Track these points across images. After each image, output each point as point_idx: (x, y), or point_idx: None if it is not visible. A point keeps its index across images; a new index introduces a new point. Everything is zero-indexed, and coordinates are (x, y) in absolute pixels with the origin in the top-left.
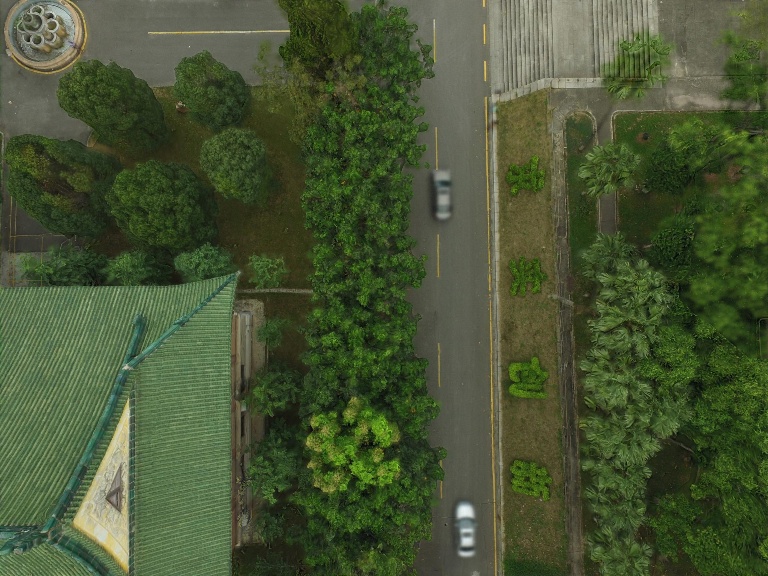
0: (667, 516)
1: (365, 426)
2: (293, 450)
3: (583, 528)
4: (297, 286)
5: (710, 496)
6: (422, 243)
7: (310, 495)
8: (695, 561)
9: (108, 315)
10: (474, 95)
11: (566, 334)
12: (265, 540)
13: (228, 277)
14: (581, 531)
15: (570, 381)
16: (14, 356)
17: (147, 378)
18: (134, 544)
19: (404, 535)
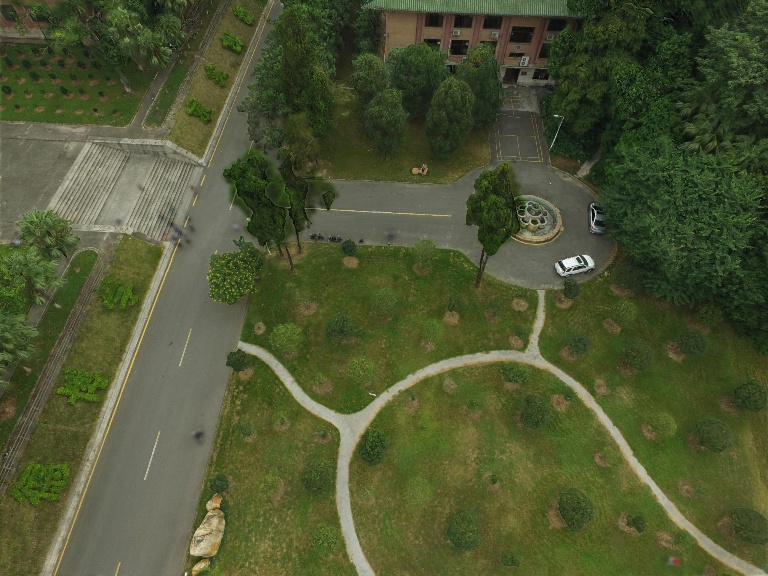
0: None
1: None
2: (357, 7)
3: None
4: None
5: None
6: None
7: None
8: None
9: None
10: (216, 169)
11: None
12: None
13: (367, 5)
14: None
15: None
16: None
17: None
18: None
19: None
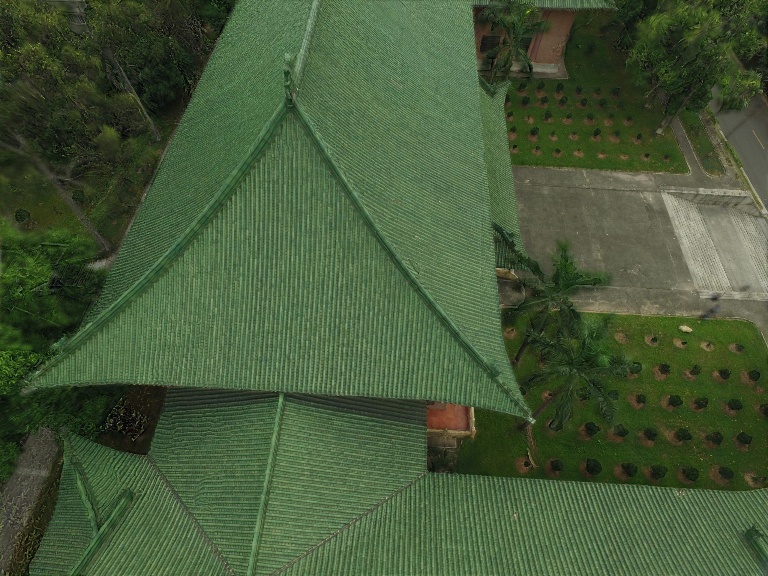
0: None
1: None
2: None
3: None
4: None
5: None
6: None
7: None
8: None
9: None
10: None
11: None
12: None
13: None
14: None
15: None
16: None
17: None
18: None
19: None
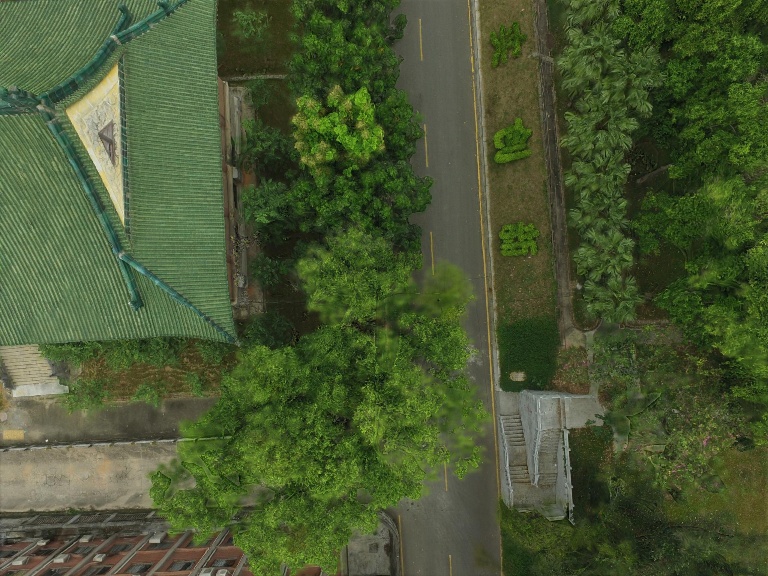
0: (648, 214)
1: (348, 100)
2: None
3: (571, 273)
4: (284, 72)
5: (687, 169)
6: (405, 28)
7: (299, 185)
8: (675, 237)
9: (95, 16)
10: None
11: (547, 88)
12: (262, 311)
13: None
14: (569, 277)
15: (553, 134)
16: (5, 43)
17: (135, 59)
18: (129, 210)
19: (394, 255)
